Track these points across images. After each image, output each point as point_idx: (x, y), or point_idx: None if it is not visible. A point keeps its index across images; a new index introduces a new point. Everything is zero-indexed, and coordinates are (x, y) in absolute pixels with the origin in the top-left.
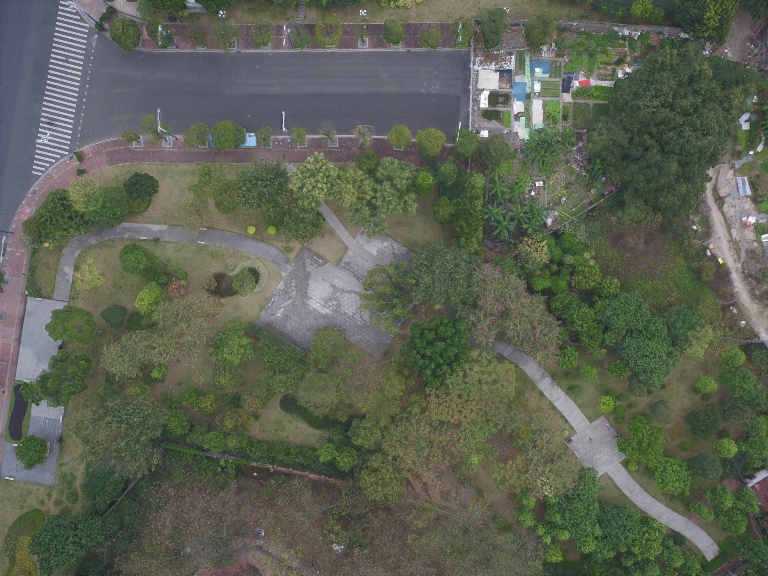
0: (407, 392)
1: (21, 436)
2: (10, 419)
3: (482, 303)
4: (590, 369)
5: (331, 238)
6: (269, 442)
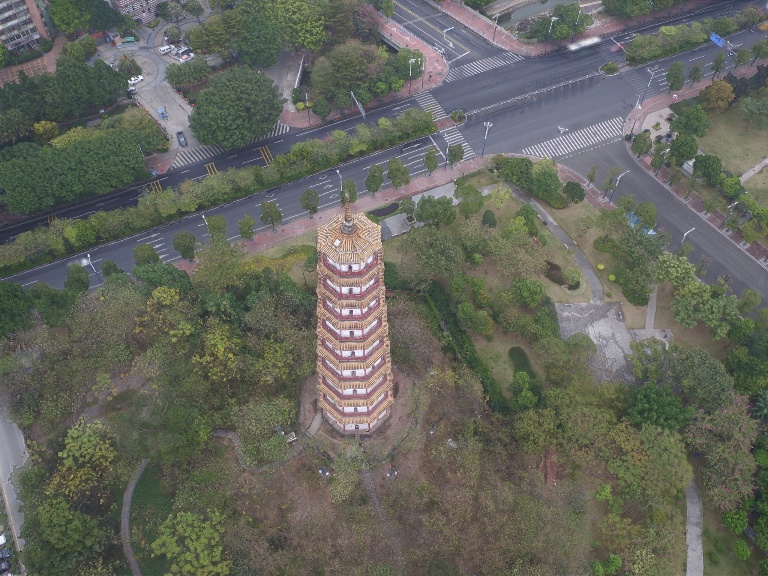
0: (608, 408)
1: None
2: (373, 210)
3: (716, 413)
4: (746, 546)
5: (640, 315)
6: None
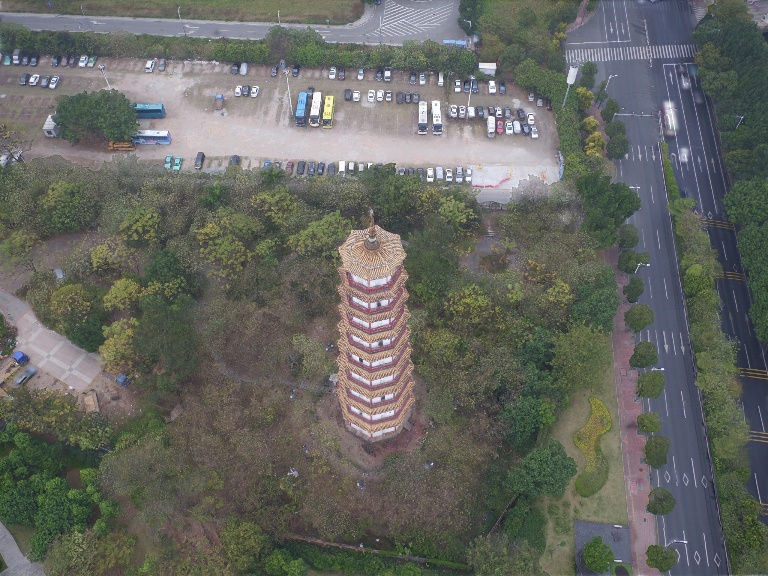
0: None
1: (616, 571)
2: None
3: None
4: None
5: None
6: (364, 575)
